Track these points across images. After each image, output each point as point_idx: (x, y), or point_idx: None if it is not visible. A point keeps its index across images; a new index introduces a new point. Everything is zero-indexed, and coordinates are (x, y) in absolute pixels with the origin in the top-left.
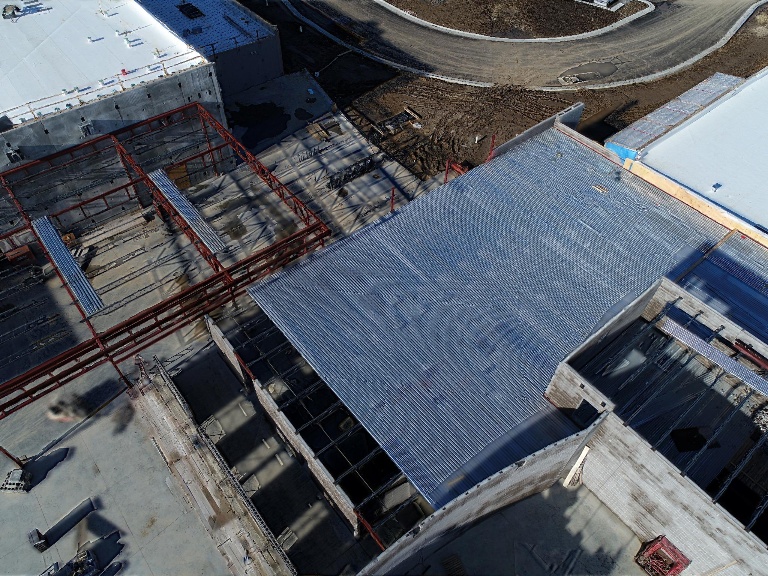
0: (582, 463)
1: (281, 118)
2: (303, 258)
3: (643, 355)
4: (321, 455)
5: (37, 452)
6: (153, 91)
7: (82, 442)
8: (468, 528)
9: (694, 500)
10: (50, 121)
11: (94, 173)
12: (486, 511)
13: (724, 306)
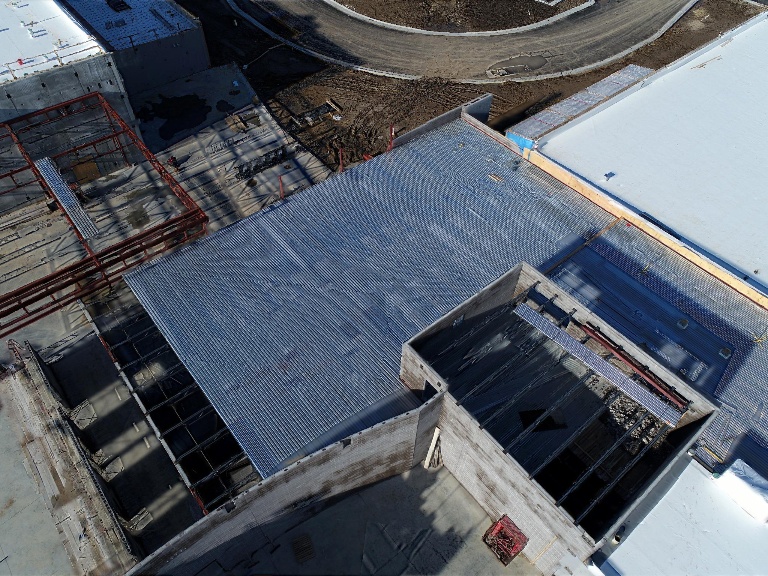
0: (438, 445)
1: (202, 110)
2: (185, 245)
3: (508, 339)
4: (167, 435)
5: None
6: (47, 80)
7: None
8: (322, 508)
9: (517, 477)
10: None
11: None
12: (336, 491)
13: (596, 291)
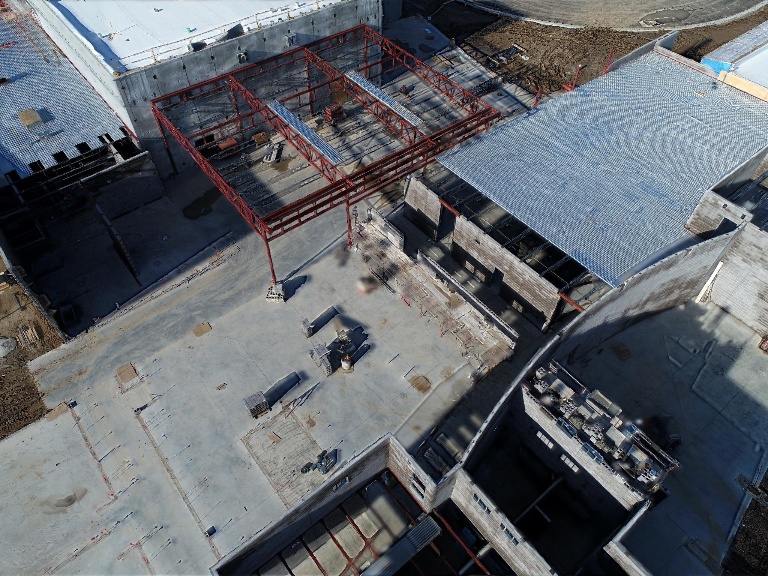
0: (714, 279)
1: (408, 51)
2: (473, 139)
3: None
4: (525, 260)
5: (283, 278)
6: (338, 11)
7: (315, 272)
8: (628, 325)
9: None
10: (269, 31)
11: (286, 81)
12: (645, 308)
13: None
